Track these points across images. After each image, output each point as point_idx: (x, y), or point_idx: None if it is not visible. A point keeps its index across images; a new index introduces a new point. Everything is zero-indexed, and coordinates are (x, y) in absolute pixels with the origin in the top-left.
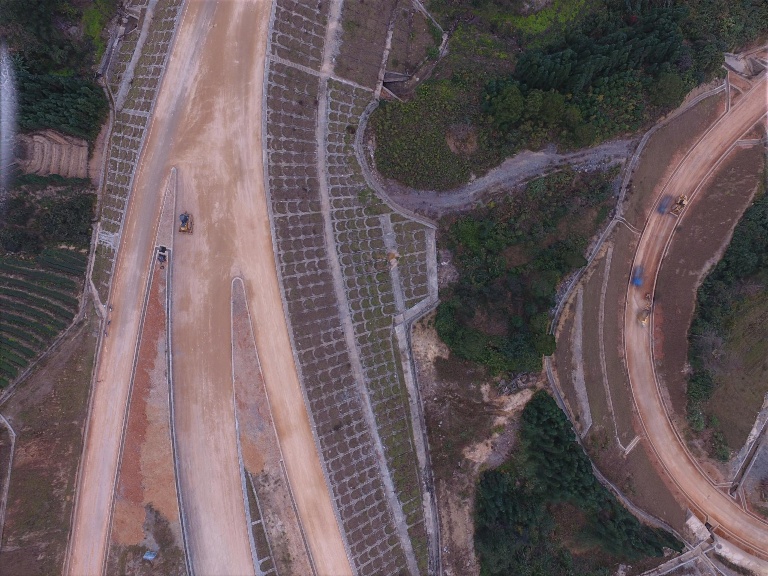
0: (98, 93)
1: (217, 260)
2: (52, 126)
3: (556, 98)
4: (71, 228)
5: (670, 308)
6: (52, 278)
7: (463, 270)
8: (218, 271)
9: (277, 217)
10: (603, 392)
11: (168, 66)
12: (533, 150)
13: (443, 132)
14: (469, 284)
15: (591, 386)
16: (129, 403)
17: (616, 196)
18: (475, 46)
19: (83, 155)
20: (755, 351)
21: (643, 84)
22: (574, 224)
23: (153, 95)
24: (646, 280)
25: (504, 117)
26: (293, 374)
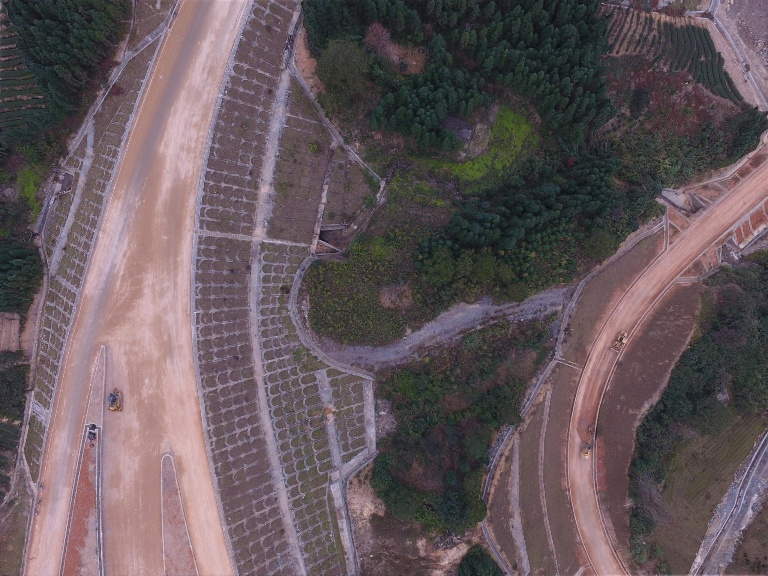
0: (32, 259)
1: (147, 437)
2: None
3: (485, 265)
4: (4, 401)
5: (612, 443)
6: None
7: (401, 420)
8: (148, 448)
9: (207, 392)
10: (544, 532)
11: (97, 243)
12: (468, 303)
13: (376, 293)
14: (406, 436)
15: (530, 532)
16: None
17: (555, 338)
18: (412, 193)
19: (15, 328)
20: (698, 480)
21: (576, 238)
22: (513, 367)
23: (82, 272)
24: (588, 414)
25: (435, 280)
26: (223, 549)
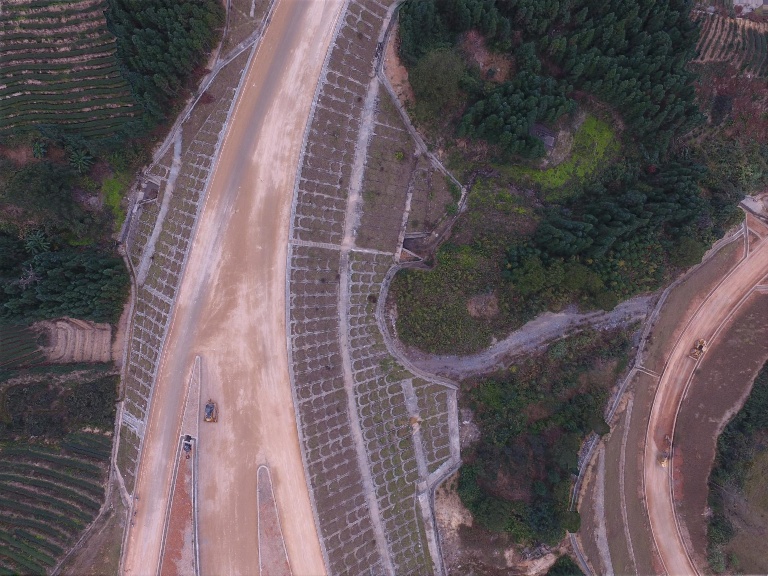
0: (119, 269)
1: (242, 448)
2: (76, 318)
3: (578, 274)
4: (95, 412)
5: (690, 452)
6: (77, 465)
7: (485, 429)
8: (243, 459)
9: (302, 403)
10: (624, 542)
11: (191, 253)
12: (554, 312)
13: (465, 302)
14: (491, 445)
15: (613, 541)
16: None
17: (636, 346)
18: (494, 201)
19: (106, 339)
20: None
21: (663, 246)
22: (594, 376)
23: (176, 282)
24: (665, 422)
25: (526, 289)
26: (320, 561)
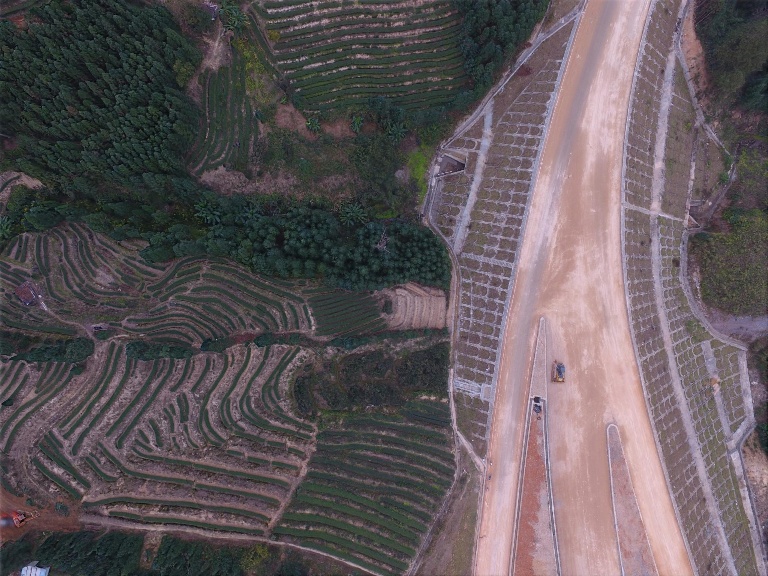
0: None
1: (590, 407)
2: (427, 283)
3: None
4: (433, 379)
5: None
6: (423, 432)
7: None
8: (591, 418)
9: (642, 361)
10: None
11: (528, 217)
12: None
13: None
14: None
15: None
16: (514, 558)
17: None
18: (761, 170)
19: (442, 305)
20: None
21: None
22: None
23: (516, 246)
24: None
25: None
26: (671, 518)
